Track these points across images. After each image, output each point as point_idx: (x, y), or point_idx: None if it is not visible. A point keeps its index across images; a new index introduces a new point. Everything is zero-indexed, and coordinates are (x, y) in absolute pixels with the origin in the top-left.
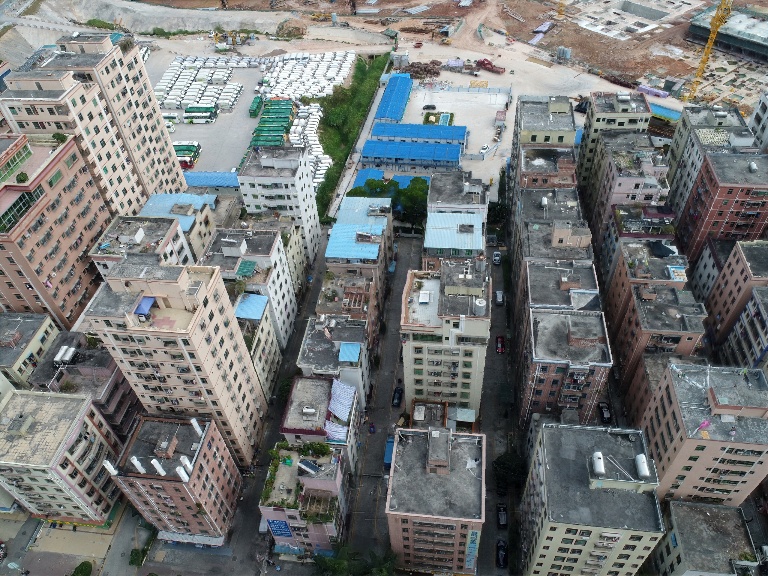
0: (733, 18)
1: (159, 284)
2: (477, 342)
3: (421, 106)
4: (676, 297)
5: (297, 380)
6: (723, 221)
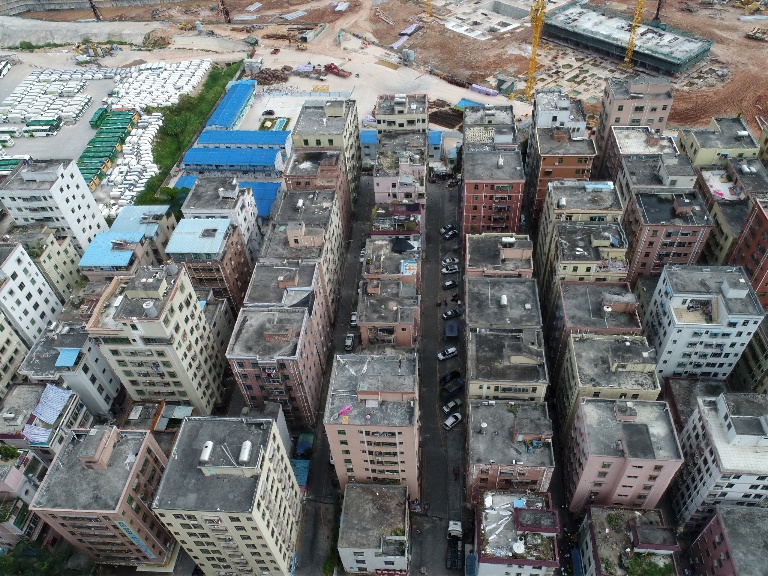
0: (584, 16)
1: None
2: (163, 342)
3: (261, 112)
4: (398, 290)
5: (15, 387)
6: (480, 215)
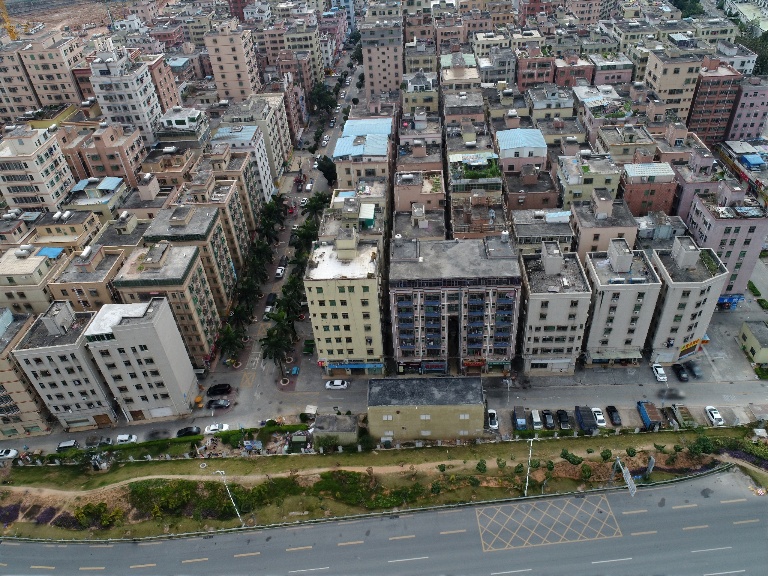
0: None
1: (231, 23)
2: None
3: None
4: None
5: None
6: None
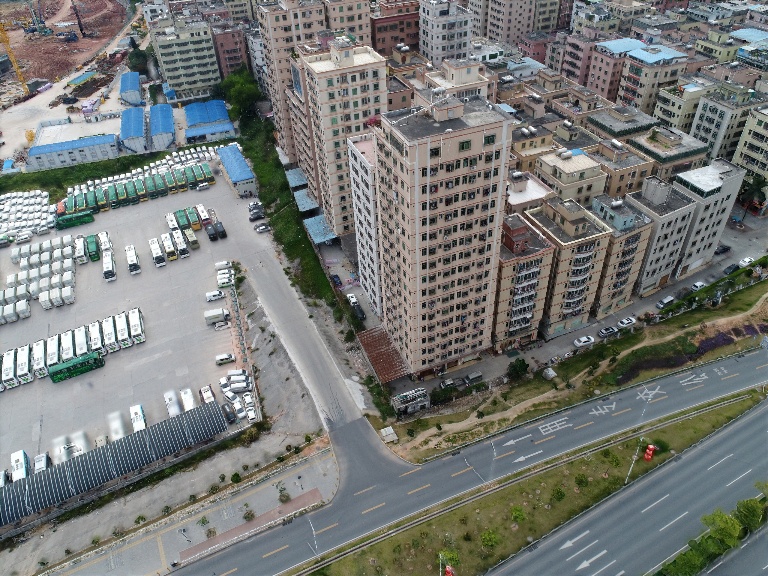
0: None
1: None
2: None
3: None
4: None
5: None
6: None
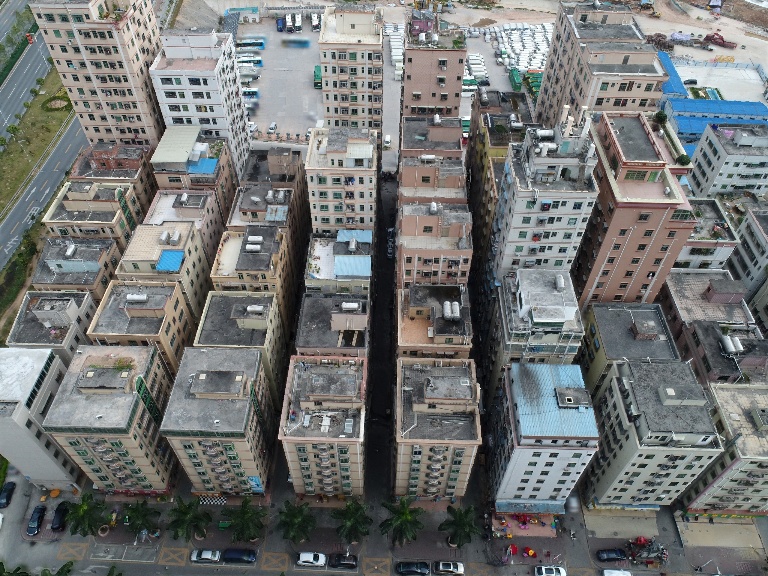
0: None
1: None
2: None
3: None
4: None
5: None
6: None
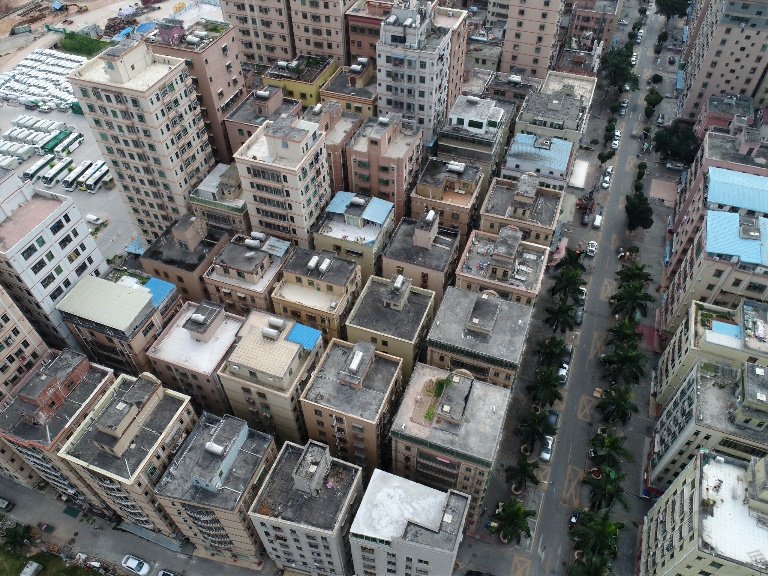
0: None
1: None
2: None
3: None
4: None
5: None
6: None
